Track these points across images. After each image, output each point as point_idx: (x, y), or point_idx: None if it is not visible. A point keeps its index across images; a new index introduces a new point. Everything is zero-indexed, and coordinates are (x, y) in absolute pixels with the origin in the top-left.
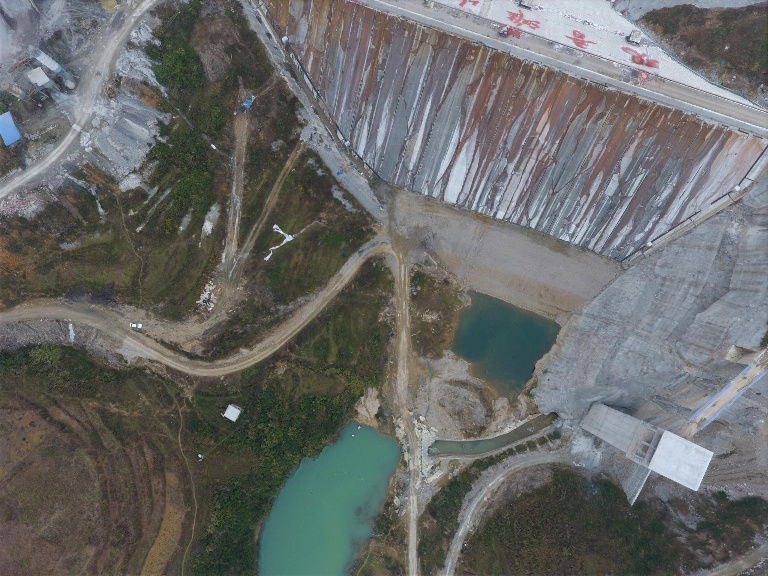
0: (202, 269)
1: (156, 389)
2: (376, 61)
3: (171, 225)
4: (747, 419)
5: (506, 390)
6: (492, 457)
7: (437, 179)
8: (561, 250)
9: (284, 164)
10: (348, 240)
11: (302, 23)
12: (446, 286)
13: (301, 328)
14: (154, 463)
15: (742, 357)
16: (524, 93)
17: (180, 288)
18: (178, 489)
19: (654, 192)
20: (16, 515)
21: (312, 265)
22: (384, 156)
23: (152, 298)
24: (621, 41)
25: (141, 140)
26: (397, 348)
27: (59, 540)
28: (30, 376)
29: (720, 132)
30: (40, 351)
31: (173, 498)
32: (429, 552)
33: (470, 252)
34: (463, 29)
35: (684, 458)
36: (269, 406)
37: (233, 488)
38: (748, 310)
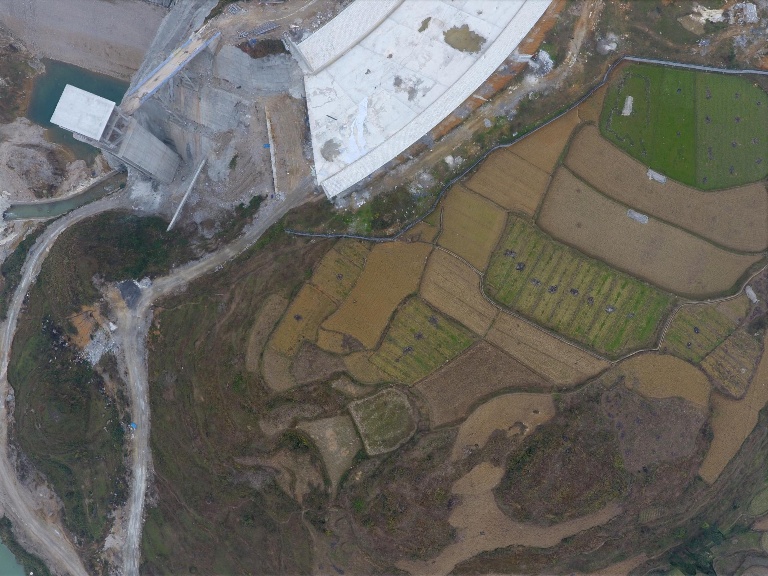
0: None
1: None
2: None
3: None
4: (238, 117)
5: (84, 153)
6: None
7: None
8: None
9: None
10: None
11: None
12: (14, 53)
13: None
14: None
15: None
16: None
17: None
18: None
19: None
20: None
21: None
22: None
23: None
24: None
25: None
26: None
27: None
28: None
29: None
30: None
31: None
32: None
33: (27, 12)
34: None
35: (86, 109)
36: None
37: None
38: (212, 0)
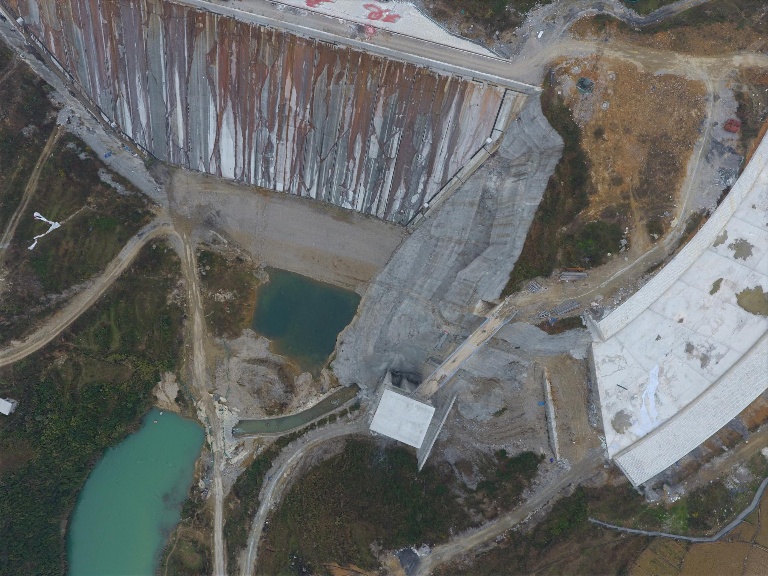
0: None
1: None
2: (113, 36)
3: None
4: (512, 374)
5: (310, 365)
6: (295, 433)
7: (209, 155)
8: (344, 218)
9: (41, 150)
10: (123, 223)
11: (31, 2)
12: (240, 264)
13: (78, 316)
14: None
15: (489, 311)
16: (261, 58)
17: None
18: None
19: (414, 151)
20: None
21: (85, 251)
22: (152, 135)
23: None
24: None
25: None
26: (192, 330)
27: None
28: None
29: (456, 83)
30: None
31: None
32: (233, 533)
33: (257, 227)
34: None
35: (405, 416)
36: (48, 397)
37: (11, 482)
38: (496, 263)
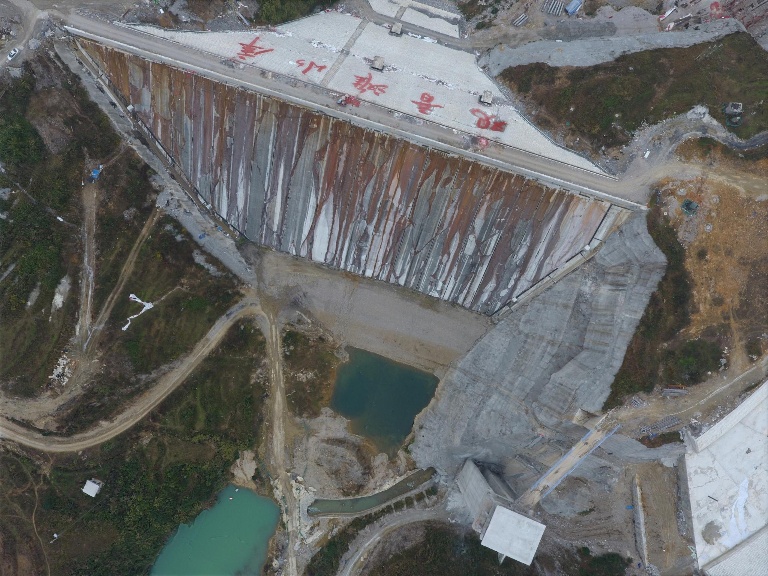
0: (53, 344)
1: (9, 468)
2: (223, 129)
3: (16, 301)
4: (602, 478)
5: (386, 445)
6: (371, 515)
7: (302, 240)
8: (431, 306)
9: (140, 232)
10: (213, 304)
11: (145, 92)
12: (322, 343)
13: (165, 396)
14: (4, 547)
15: (588, 420)
16: (371, 159)
17: (30, 364)
18: (30, 572)
19: (511, 251)
20: None
21: (175, 331)
22: (247, 218)
23: None
24: (473, 102)
25: None
26: (272, 409)
27: None
28: None
29: (563, 196)
30: None
31: None
32: None
33: (343, 310)
34: (300, 99)
35: (517, 533)
36: (133, 478)
37: (94, 565)
38: (595, 372)
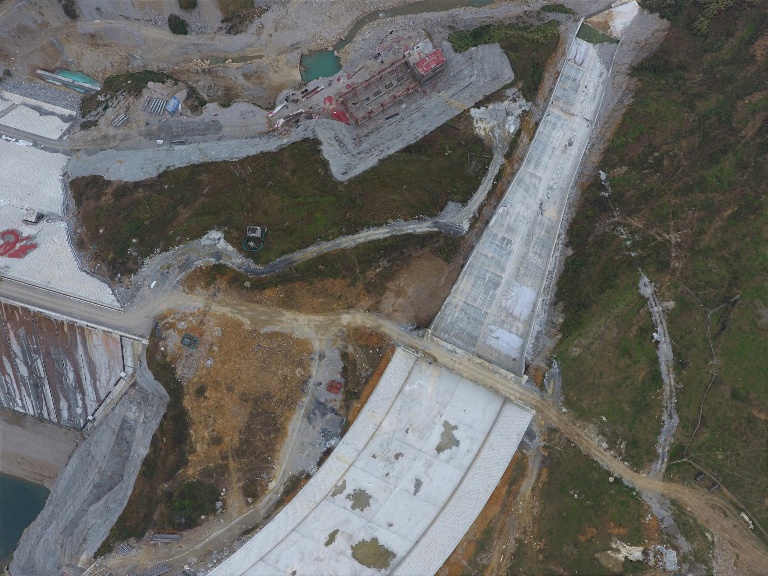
0: None
1: None
2: None
3: None
4: None
5: None
6: None
7: None
8: (17, 422)
9: None
10: None
11: None
12: None
13: None
14: None
15: None
16: None
17: None
18: None
19: (61, 374)
20: None
21: None
22: None
23: None
24: (16, 220)
25: None
26: None
27: None
28: None
29: (73, 327)
30: None
31: None
32: None
33: None
34: None
35: None
36: None
37: None
38: (108, 511)
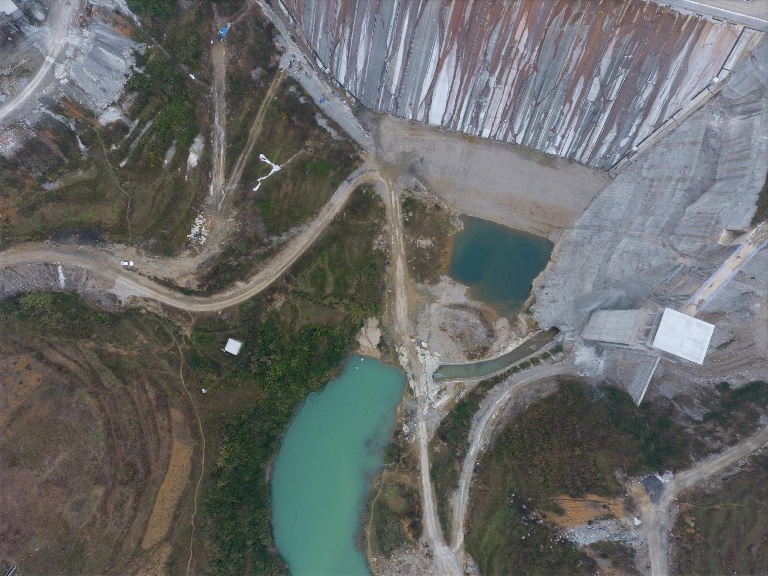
0: (190, 202)
1: (153, 327)
2: None
3: (155, 158)
4: (743, 305)
5: (505, 311)
6: (497, 377)
7: (420, 101)
8: (548, 164)
9: (265, 93)
10: (336, 168)
11: None
12: (438, 211)
13: (296, 259)
14: (157, 399)
15: (734, 240)
16: None
17: (170, 223)
18: (184, 424)
19: (635, 93)
20: (19, 460)
21: (302, 195)
22: (365, 81)
23: (142, 234)
24: None
25: (117, 71)
26: (394, 276)
27: (66, 482)
28: (22, 320)
29: (695, 22)
30: (30, 296)
31: (180, 433)
32: (442, 475)
33: (459, 174)
34: None
35: (687, 333)
36: (270, 338)
37: (240, 422)
38: (736, 195)
